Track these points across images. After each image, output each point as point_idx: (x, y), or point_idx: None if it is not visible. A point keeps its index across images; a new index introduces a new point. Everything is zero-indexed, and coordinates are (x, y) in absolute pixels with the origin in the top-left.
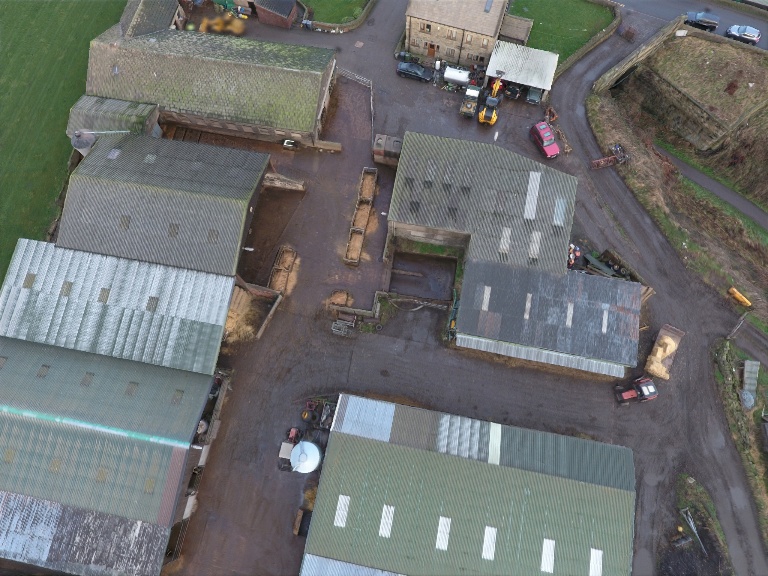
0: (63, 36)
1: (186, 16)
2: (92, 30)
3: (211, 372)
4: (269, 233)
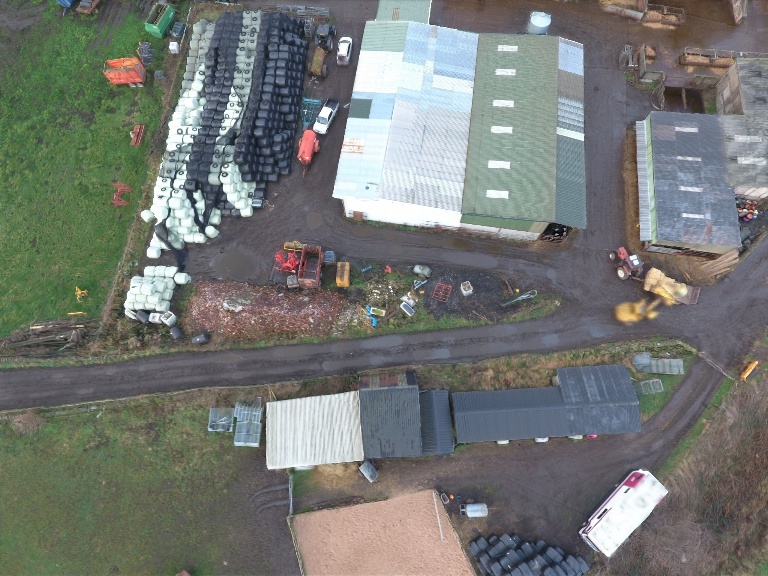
0: None
1: None
2: None
3: None
4: (690, 8)
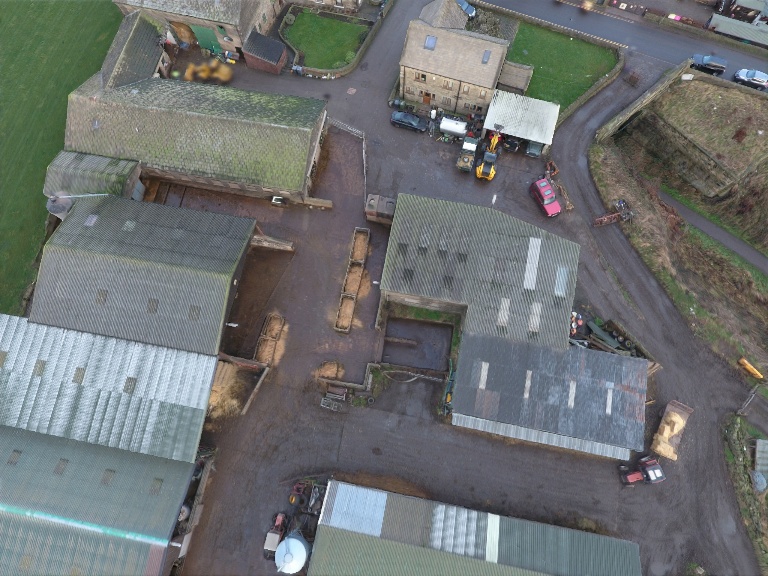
0: (43, 82)
1: (171, 61)
2: (73, 76)
3: (192, 461)
4: (256, 297)
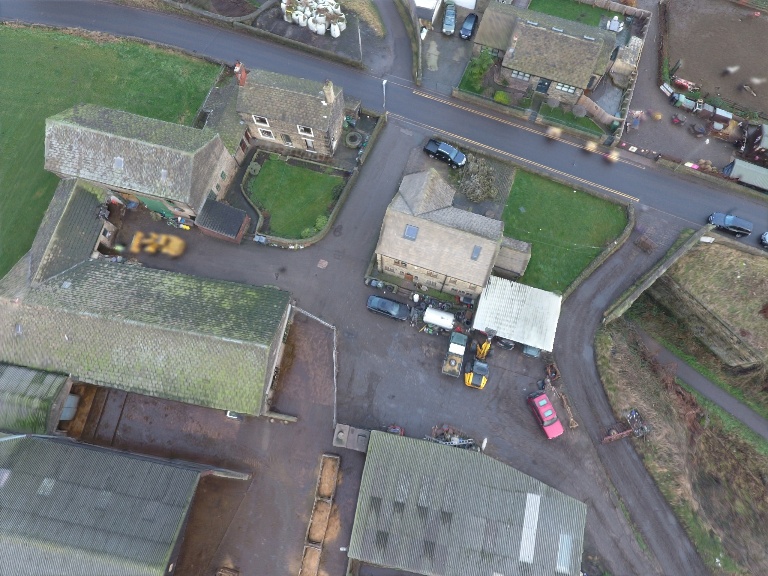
0: None
1: (116, 226)
2: (3, 244)
3: None
4: (205, 540)
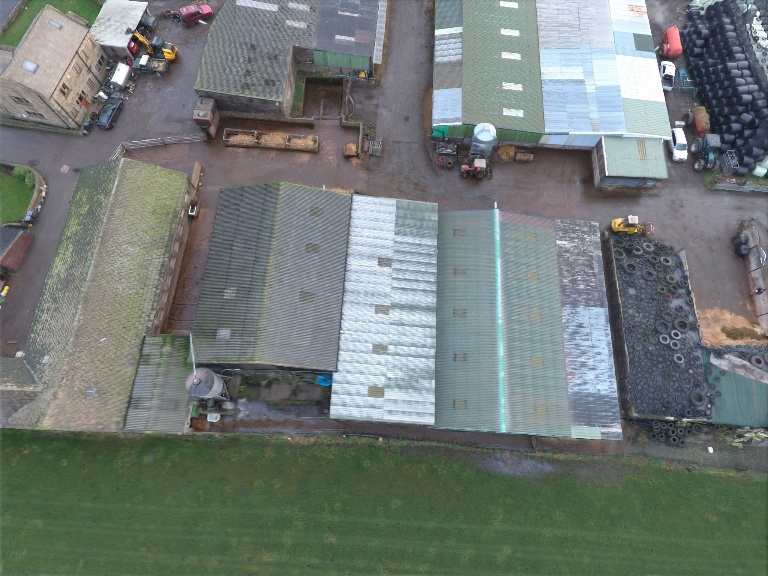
0: None
1: None
2: None
3: (436, 205)
4: None
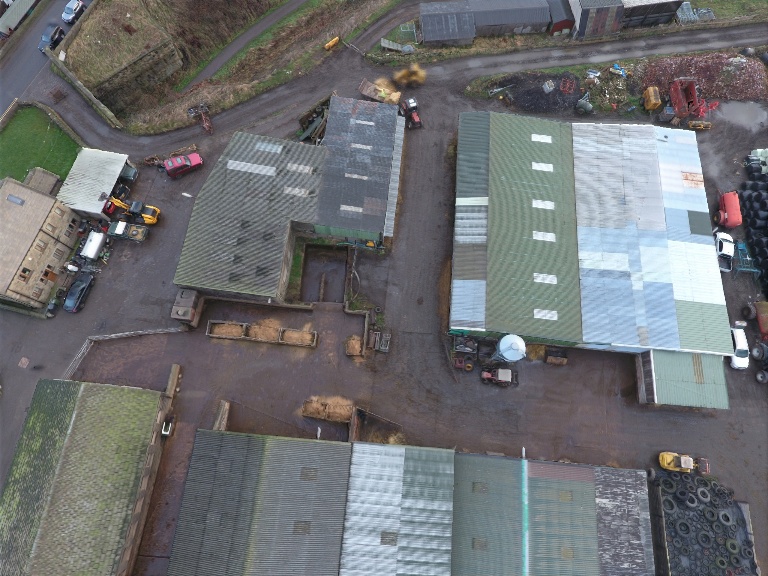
0: None
1: None
2: None
3: (452, 452)
4: None
